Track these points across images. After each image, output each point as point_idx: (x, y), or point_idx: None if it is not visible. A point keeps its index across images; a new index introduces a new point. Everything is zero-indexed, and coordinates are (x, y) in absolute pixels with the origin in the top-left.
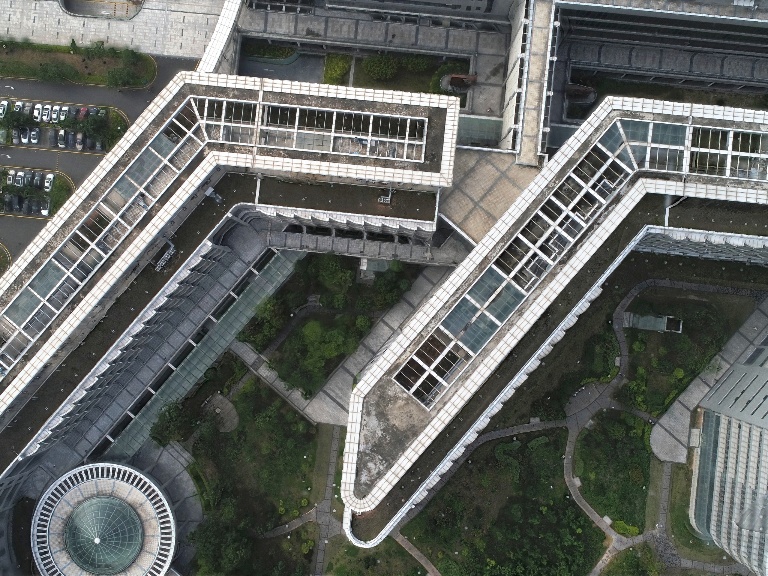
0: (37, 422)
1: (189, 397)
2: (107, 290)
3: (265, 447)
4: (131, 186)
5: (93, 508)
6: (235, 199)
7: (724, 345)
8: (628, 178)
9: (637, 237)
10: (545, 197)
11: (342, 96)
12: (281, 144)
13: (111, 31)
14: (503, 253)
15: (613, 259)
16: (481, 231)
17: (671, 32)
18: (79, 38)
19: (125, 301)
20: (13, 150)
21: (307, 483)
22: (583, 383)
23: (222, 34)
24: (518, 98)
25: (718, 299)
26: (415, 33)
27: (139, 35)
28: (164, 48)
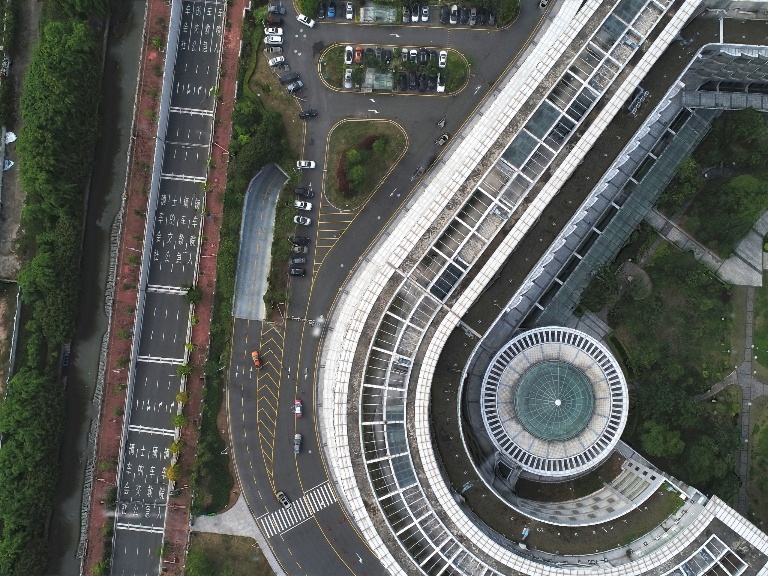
0: (518, 274)
1: (613, 261)
2: (604, 128)
3: (709, 301)
4: (619, 24)
5: (544, 372)
6: (699, 41)
7: None
8: None
9: None
10: None
11: None
12: None
13: None
14: None
15: None
16: None
17: None
18: None
19: (598, 147)
20: (402, 29)
21: (726, 346)
22: None
23: None
24: None
25: None
26: None
27: None
28: None
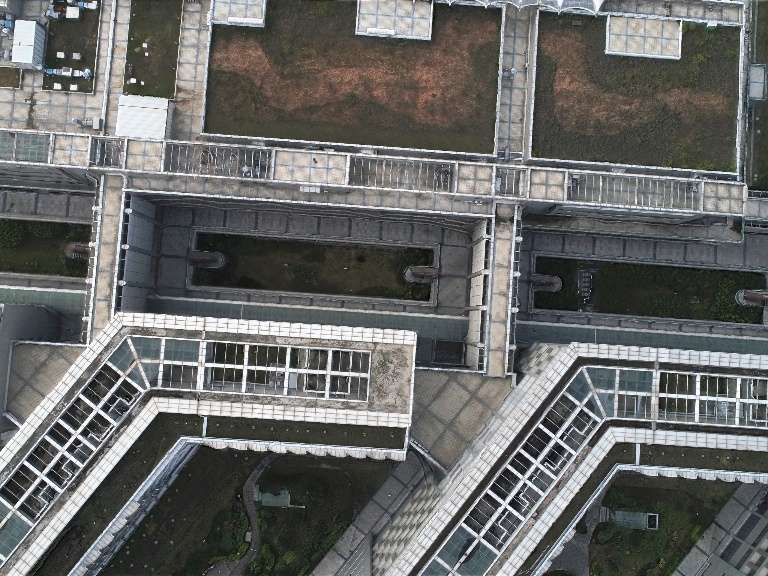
0: None
1: None
2: None
3: None
4: None
5: None
6: None
7: (358, 514)
8: (138, 398)
9: (170, 450)
10: (52, 421)
11: None
12: None
13: None
14: (9, 482)
15: (149, 473)
16: None
17: (269, 206)
18: None
19: None
20: None
21: None
22: (211, 562)
23: None
24: (88, 289)
25: (351, 467)
26: (34, 201)
27: None
28: None
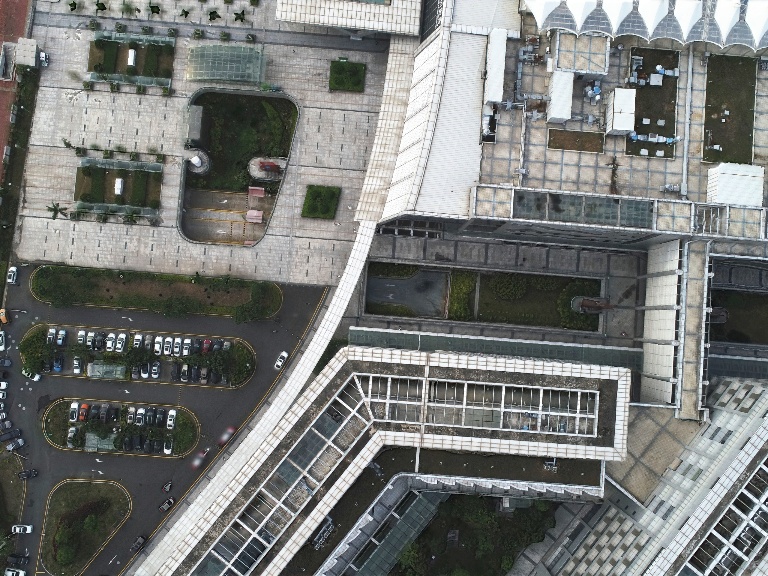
0: None
1: None
2: None
3: None
4: (294, 470)
5: None
6: (394, 467)
7: None
8: None
9: None
10: (737, 490)
11: (511, 370)
12: (449, 421)
13: (233, 258)
14: (697, 550)
15: None
16: (643, 488)
17: None
18: (200, 266)
19: None
20: (132, 385)
21: None
22: None
23: (355, 268)
24: (676, 351)
25: None
26: (546, 256)
27: (263, 262)
28: (289, 275)
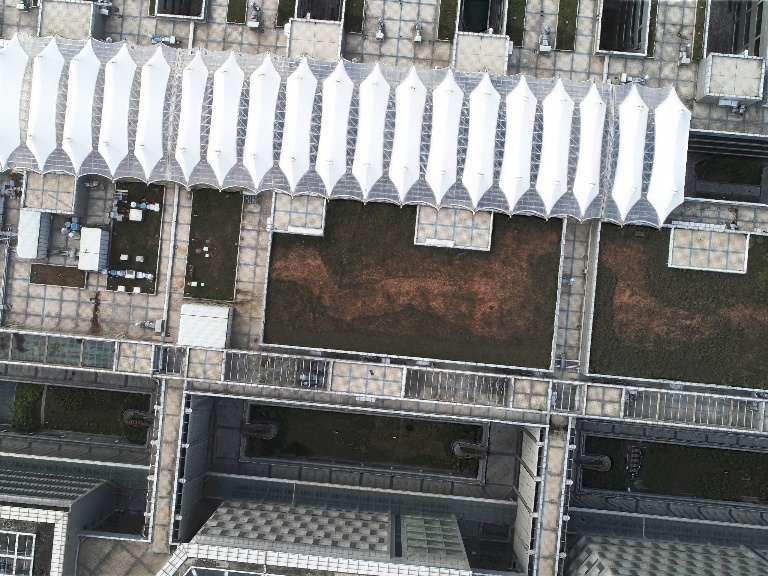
0: None
1: None
2: None
3: None
4: None
5: None
6: None
7: None
8: None
9: None
10: None
11: None
12: None
13: None
14: None
15: None
16: None
17: None
18: None
19: None
20: None
21: None
22: None
23: None
24: (150, 486)
25: None
26: None
27: None
28: None
